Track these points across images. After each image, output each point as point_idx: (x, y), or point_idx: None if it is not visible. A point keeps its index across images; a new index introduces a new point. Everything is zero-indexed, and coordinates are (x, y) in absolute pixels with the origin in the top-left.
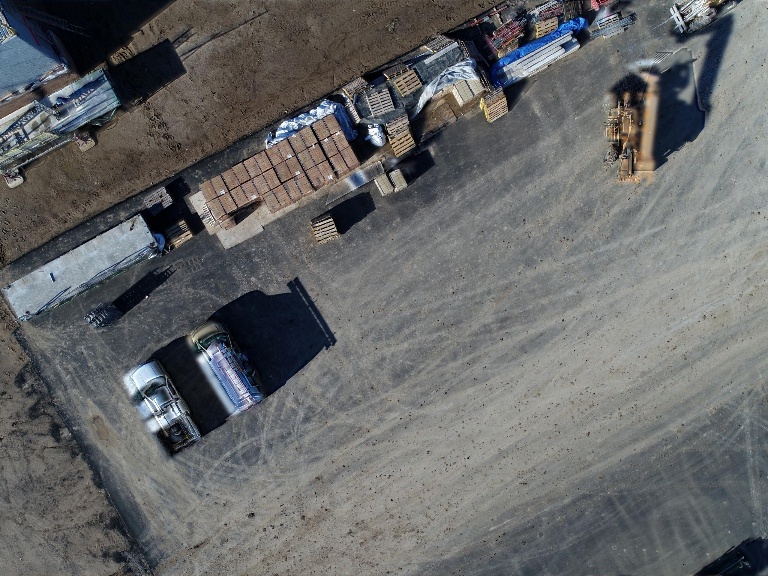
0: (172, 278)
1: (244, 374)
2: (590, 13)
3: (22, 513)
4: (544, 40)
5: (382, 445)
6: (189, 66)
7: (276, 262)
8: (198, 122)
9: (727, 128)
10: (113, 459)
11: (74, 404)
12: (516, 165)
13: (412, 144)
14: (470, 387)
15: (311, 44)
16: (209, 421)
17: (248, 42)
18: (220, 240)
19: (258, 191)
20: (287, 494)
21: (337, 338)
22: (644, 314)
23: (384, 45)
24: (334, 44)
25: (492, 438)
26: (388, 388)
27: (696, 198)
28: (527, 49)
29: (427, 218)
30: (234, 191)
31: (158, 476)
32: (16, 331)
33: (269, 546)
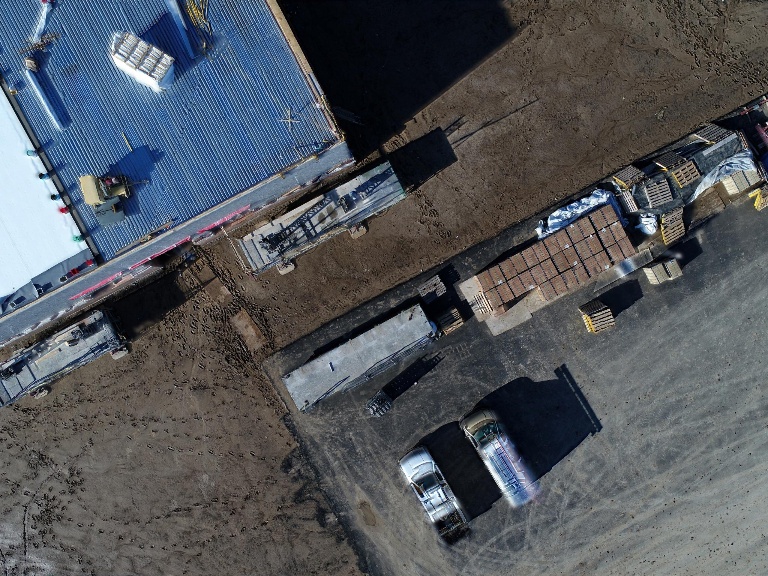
0: (441, 365)
1: (510, 460)
2: None
3: None
4: None
5: (646, 531)
6: (460, 154)
7: (544, 349)
8: (468, 209)
9: None
10: (379, 544)
11: (341, 490)
12: None
13: (682, 232)
14: (735, 473)
15: (581, 132)
16: (475, 507)
17: (519, 130)
18: (489, 327)
19: (536, 281)
20: None
21: (603, 424)
22: None
23: (653, 133)
24: (603, 132)
25: (756, 524)
26: (653, 474)
27: None
28: None
29: (694, 305)
30: (512, 281)
31: (423, 561)
32: (285, 417)
33: None
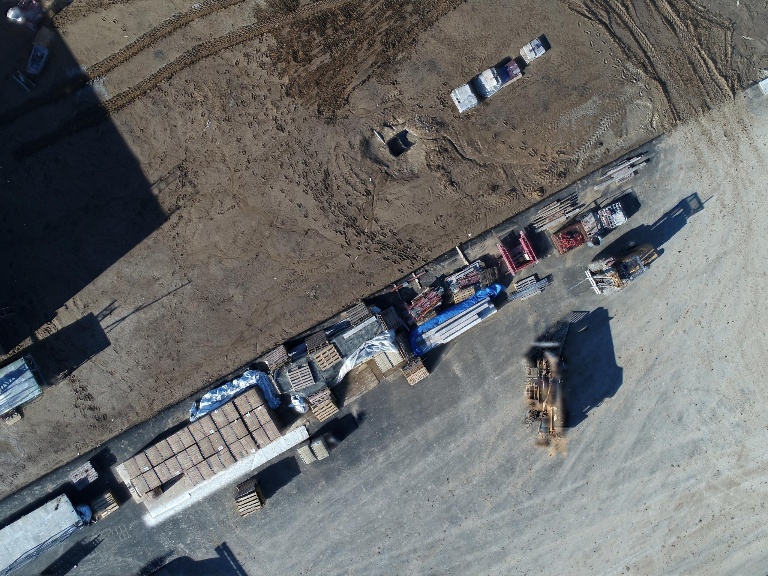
0: (100, 547)
1: None
2: (507, 275)
3: None
4: (462, 307)
5: None
6: (113, 338)
7: (203, 528)
8: (123, 392)
9: (645, 384)
10: None
11: None
12: (438, 425)
13: (335, 410)
14: None
15: (234, 313)
16: None
17: (171, 313)
18: (147, 508)
19: (182, 467)
20: None
21: None
22: (568, 568)
23: (306, 311)
24: (256, 312)
25: None
26: None
27: (616, 453)
28: (445, 317)
29: (352, 480)
30: (158, 467)
31: None
32: None
33: None
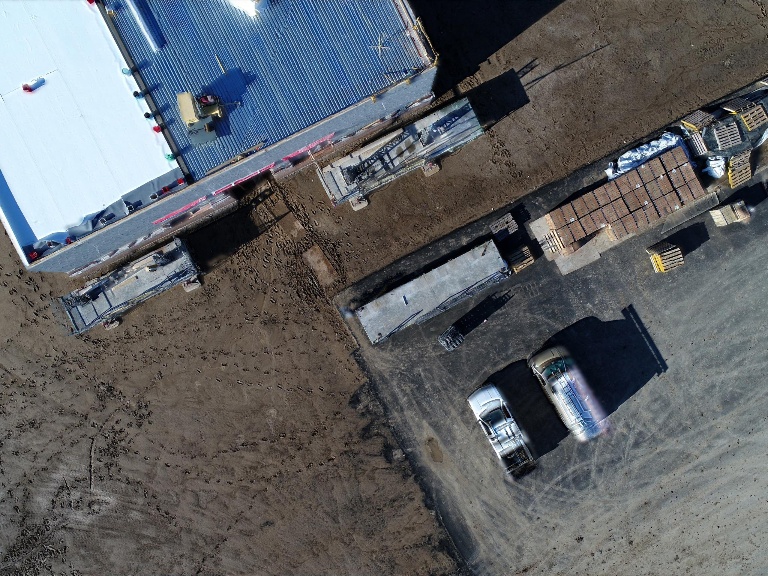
0: (510, 303)
1: (577, 399)
2: None
3: (350, 533)
4: None
5: (710, 472)
6: (532, 95)
7: (611, 289)
8: (539, 150)
9: None
10: (446, 481)
11: (410, 426)
12: None
13: (748, 176)
14: None
15: (650, 77)
16: (542, 445)
17: (590, 73)
18: (558, 266)
19: (607, 219)
20: (616, 519)
21: (668, 365)
22: None
23: (720, 79)
24: (672, 77)
25: None
26: (717, 415)
27: None
28: None
29: (759, 249)
30: (583, 219)
31: (490, 499)
32: (356, 352)
33: (597, 571)
